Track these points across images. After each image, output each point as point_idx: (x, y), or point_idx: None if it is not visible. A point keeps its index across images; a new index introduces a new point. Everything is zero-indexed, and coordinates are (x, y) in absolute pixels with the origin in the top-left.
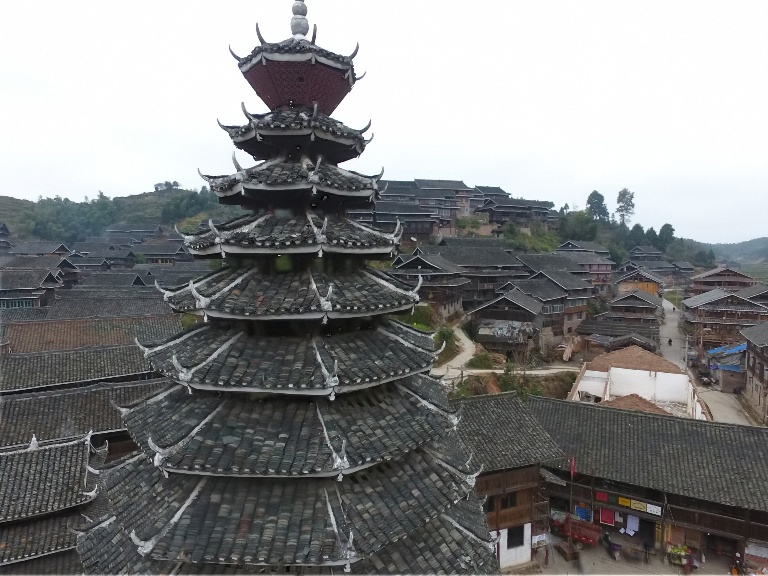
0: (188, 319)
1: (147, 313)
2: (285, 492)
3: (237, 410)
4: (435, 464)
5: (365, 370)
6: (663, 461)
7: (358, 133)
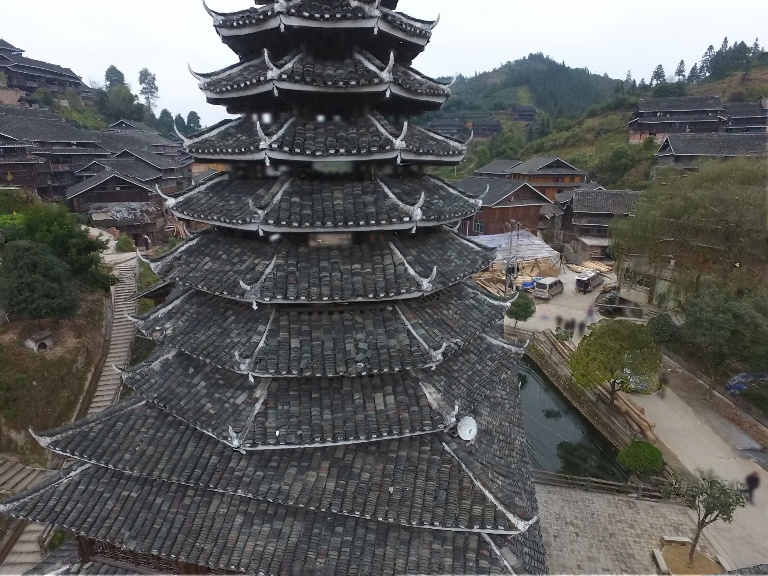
0: None
1: None
2: (436, 241)
3: (397, 184)
4: None
5: None
6: None
7: None
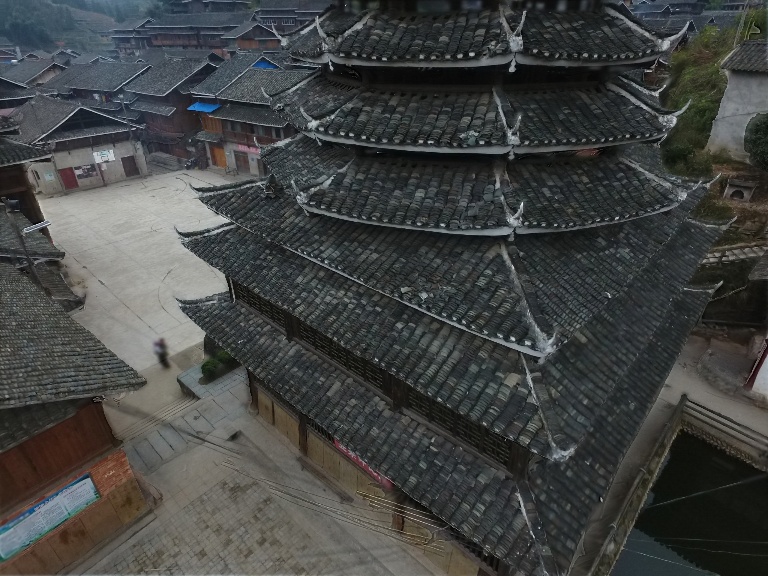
0: (684, 53)
1: None
2: None
3: None
4: (495, 21)
5: None
6: None
7: None
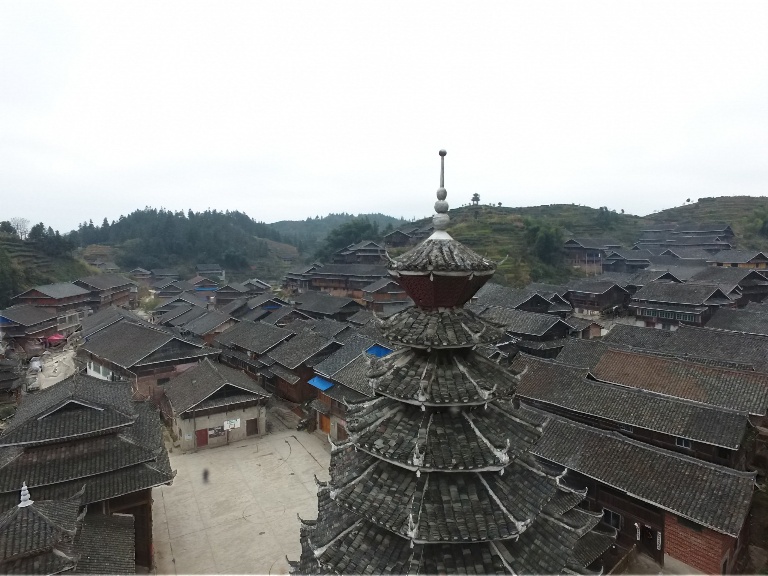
0: None
1: (764, 361)
2: None
3: None
4: None
5: (350, 564)
6: None
7: (425, 339)
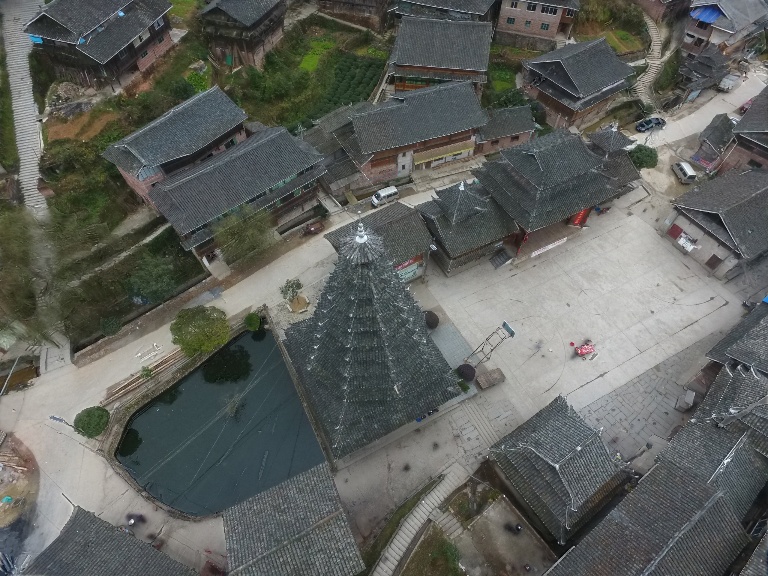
0: None
1: None
2: None
3: None
4: None
5: None
6: (126, 572)
7: None
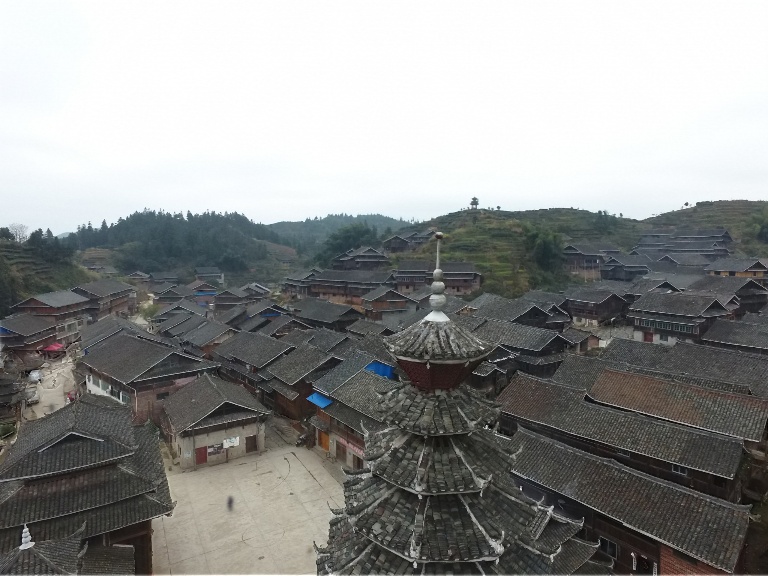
0: None
1: (760, 381)
2: None
3: None
4: None
5: None
6: None
7: (422, 428)
